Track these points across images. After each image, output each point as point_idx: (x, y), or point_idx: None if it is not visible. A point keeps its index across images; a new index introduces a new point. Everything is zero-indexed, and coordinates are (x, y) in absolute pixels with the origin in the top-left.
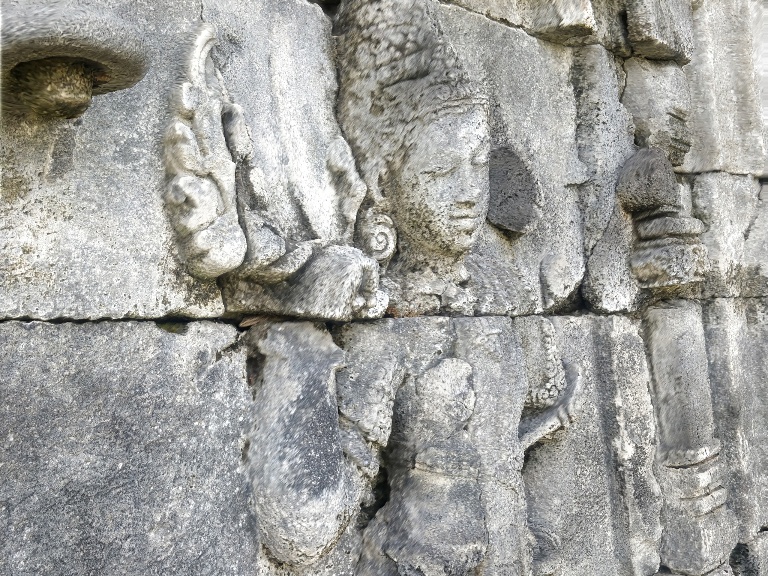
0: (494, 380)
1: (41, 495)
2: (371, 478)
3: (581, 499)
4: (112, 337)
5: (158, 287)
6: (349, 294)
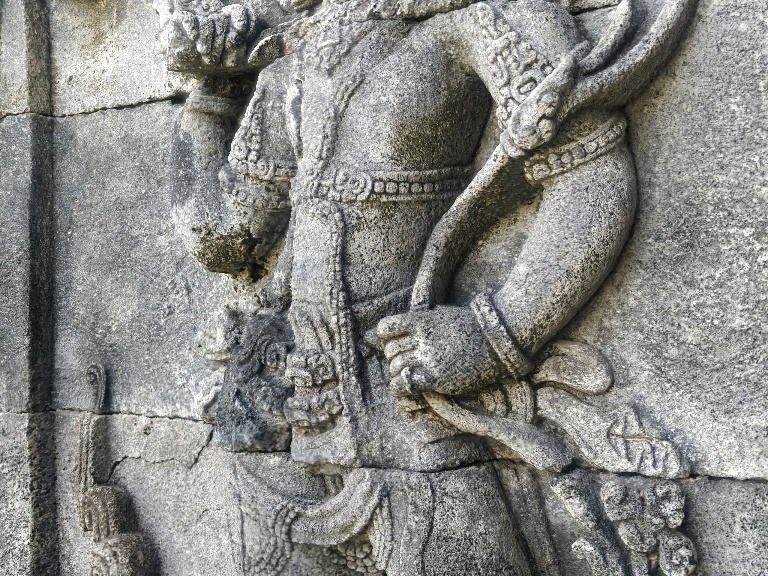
0: (321, 100)
1: (105, 203)
2: (250, 207)
3: (761, 306)
4: (143, 113)
5: (166, 77)
6: (168, 47)
